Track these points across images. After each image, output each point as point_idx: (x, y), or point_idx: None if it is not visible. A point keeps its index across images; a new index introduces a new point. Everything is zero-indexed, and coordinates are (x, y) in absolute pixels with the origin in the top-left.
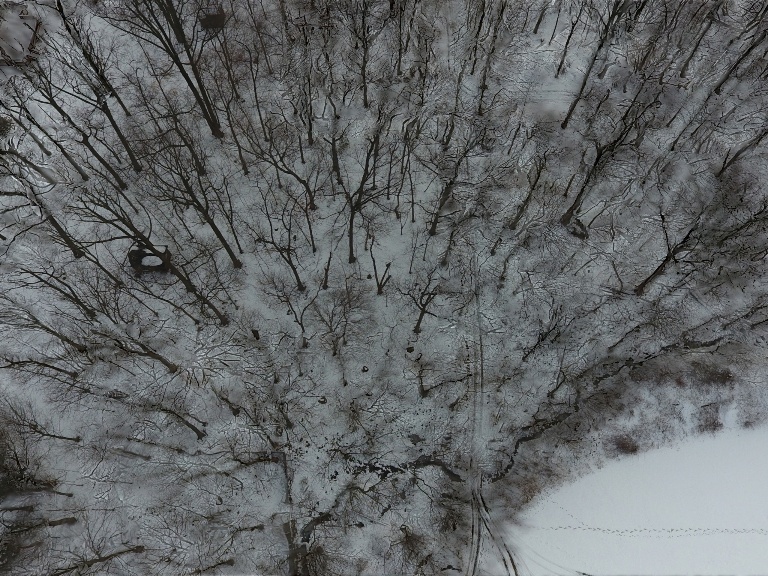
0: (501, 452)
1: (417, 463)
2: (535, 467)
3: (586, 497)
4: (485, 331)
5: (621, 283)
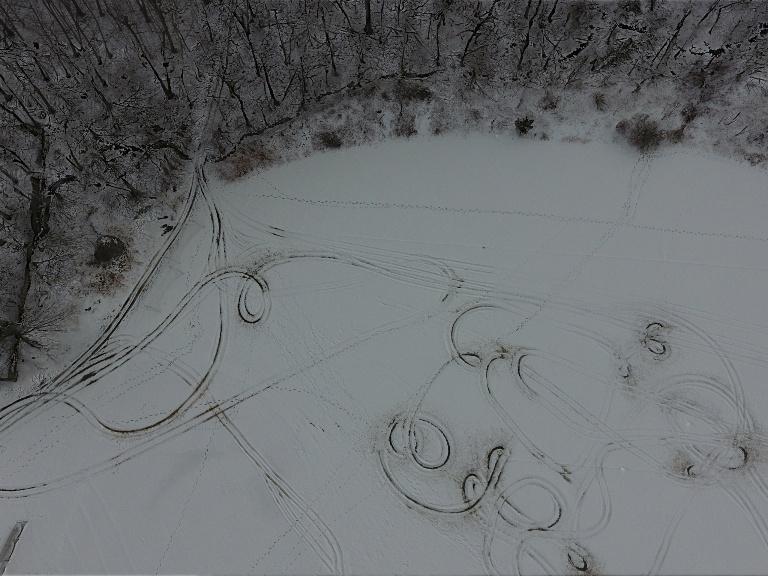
0: (218, 132)
1: (155, 145)
2: (252, 152)
3: (290, 176)
4: (231, 53)
5: (345, 15)
